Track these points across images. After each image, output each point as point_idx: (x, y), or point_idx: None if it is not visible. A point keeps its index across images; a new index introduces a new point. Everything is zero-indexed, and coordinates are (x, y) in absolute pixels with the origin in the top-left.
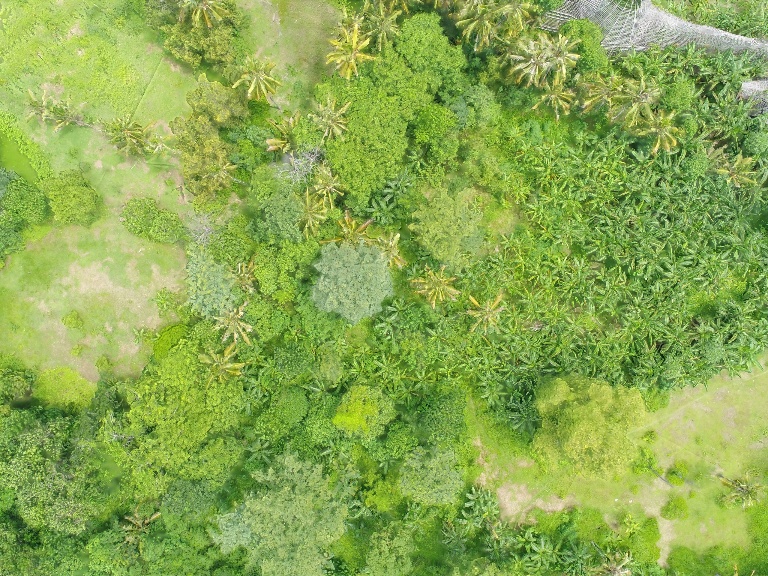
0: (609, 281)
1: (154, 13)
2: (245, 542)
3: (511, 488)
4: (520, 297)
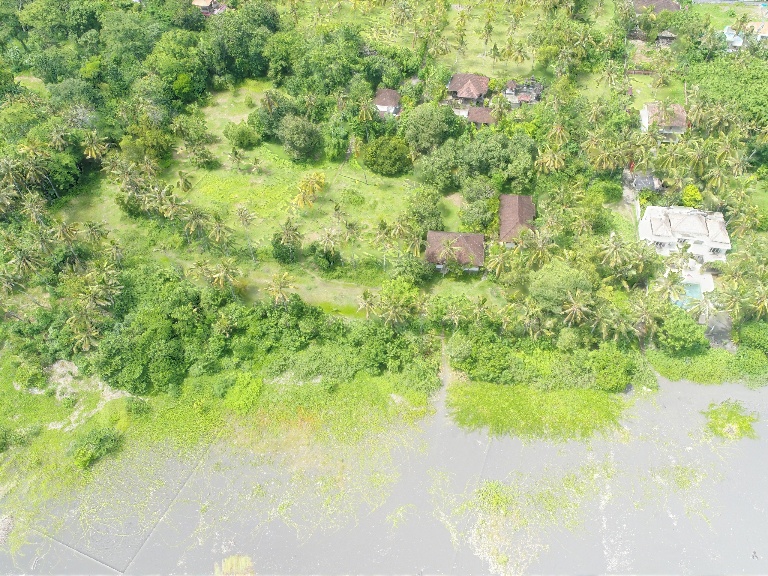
0: None
1: (161, 182)
2: None
3: (38, 81)
4: None
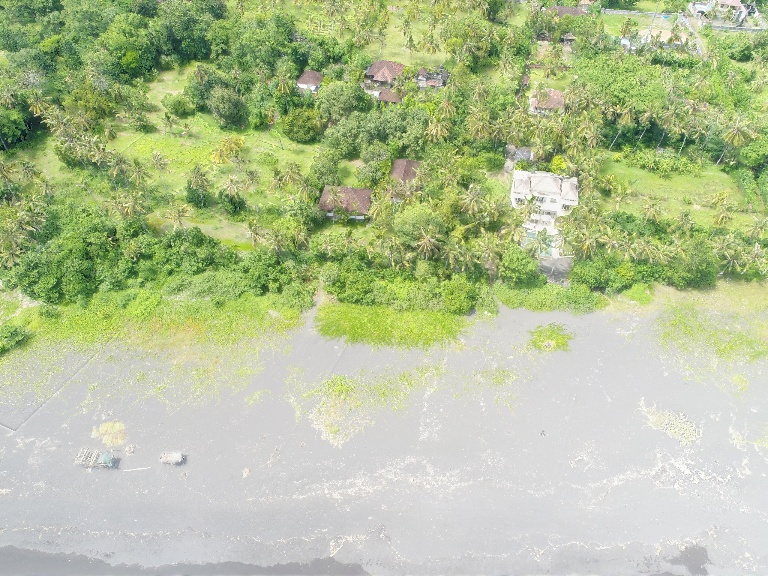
0: None
1: None
2: None
3: None
4: None
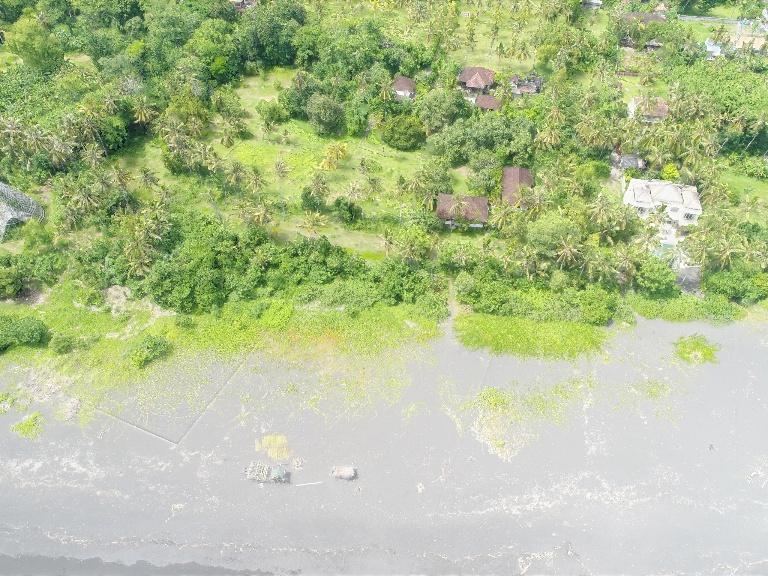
0: (5, 98)
1: (203, 144)
2: (188, 17)
3: None
4: (51, 93)
